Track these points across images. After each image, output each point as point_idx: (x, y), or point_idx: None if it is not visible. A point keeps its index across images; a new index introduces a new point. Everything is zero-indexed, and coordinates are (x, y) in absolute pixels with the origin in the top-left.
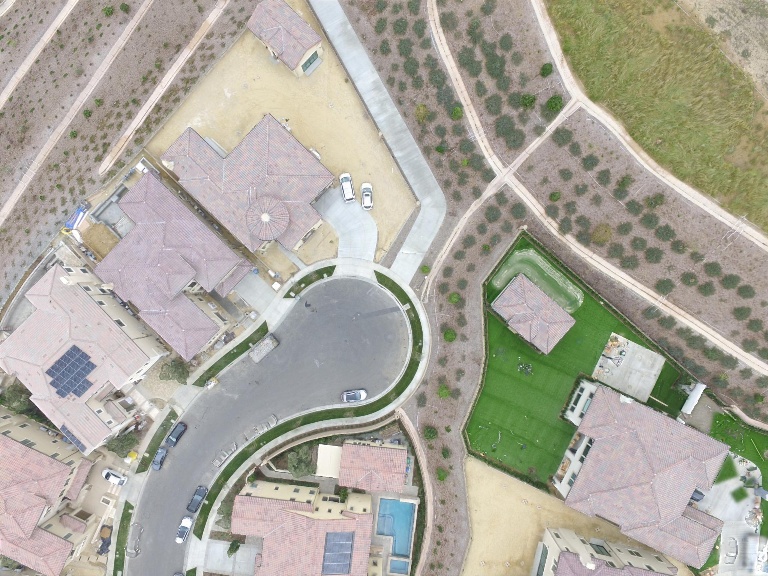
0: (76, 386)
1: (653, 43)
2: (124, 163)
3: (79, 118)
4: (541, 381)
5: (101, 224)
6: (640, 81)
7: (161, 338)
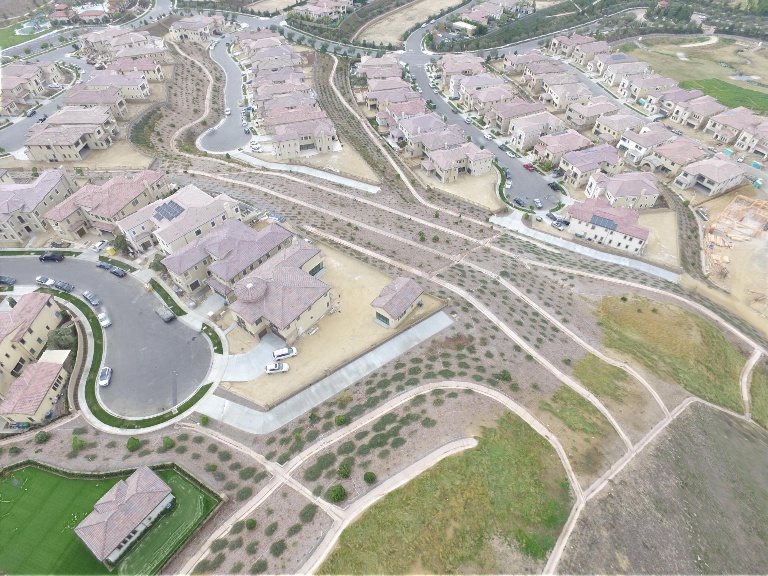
0: (160, 214)
1: (391, 574)
2: (309, 234)
3: None
4: (50, 543)
5: None
6: (354, 574)
7: None
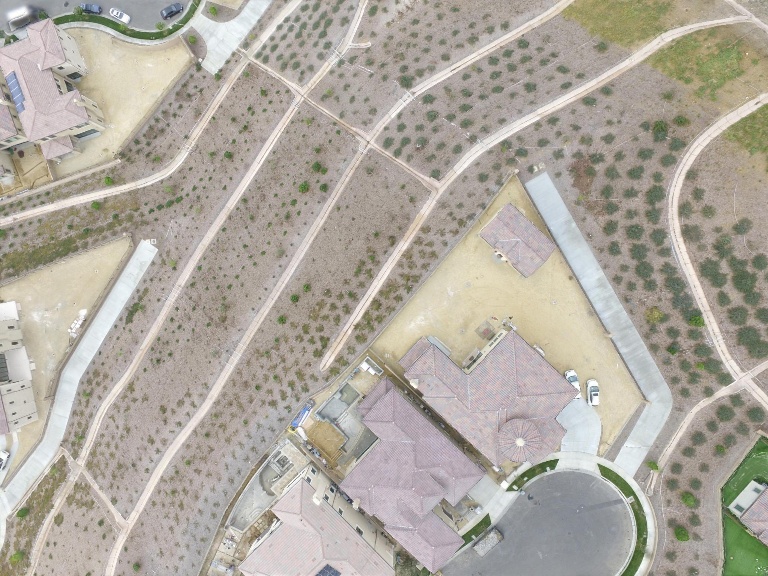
0: None
1: None
2: (347, 361)
3: (284, 301)
4: None
5: (326, 422)
6: None
7: (390, 536)
